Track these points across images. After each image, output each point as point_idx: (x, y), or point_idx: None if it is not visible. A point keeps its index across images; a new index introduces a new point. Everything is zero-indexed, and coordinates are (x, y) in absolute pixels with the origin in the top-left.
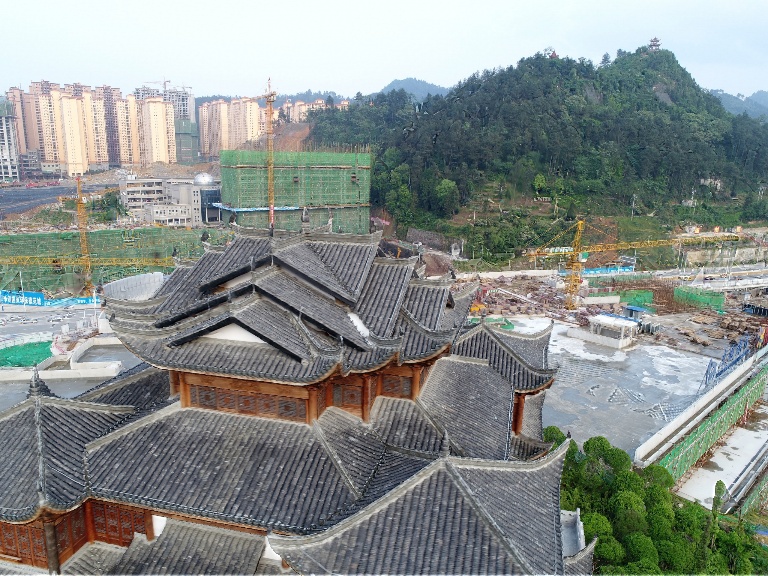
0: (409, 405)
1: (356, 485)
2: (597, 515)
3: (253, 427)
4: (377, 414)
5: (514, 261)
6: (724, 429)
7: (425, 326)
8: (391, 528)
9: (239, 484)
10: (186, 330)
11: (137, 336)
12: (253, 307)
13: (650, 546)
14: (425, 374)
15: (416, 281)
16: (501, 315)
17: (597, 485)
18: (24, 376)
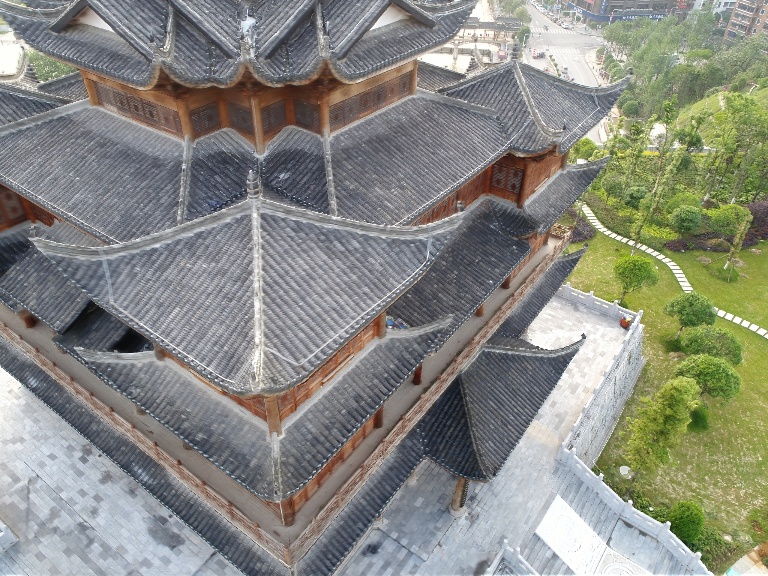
0: None
1: None
2: None
3: None
4: None
5: None
6: None
7: None
8: None
9: None
10: None
11: None
12: None
13: None
14: None
15: None
16: None
17: None
18: None
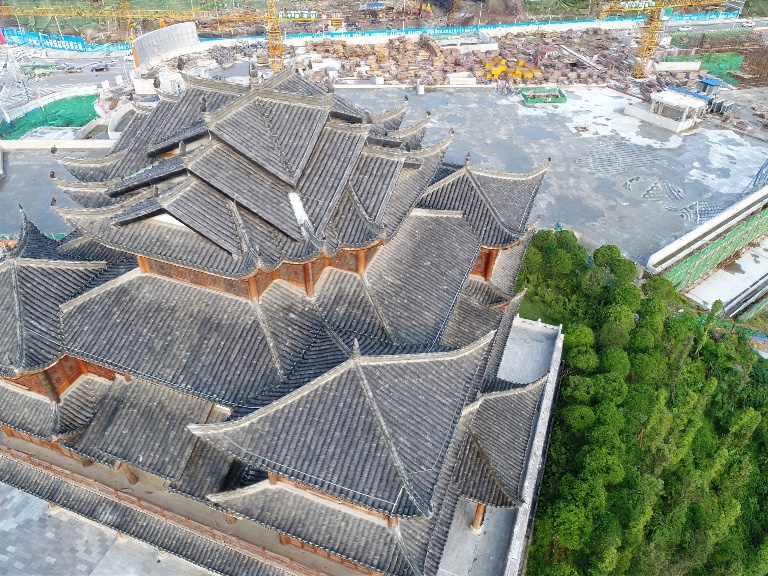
0: (354, 279)
1: (282, 369)
2: (582, 327)
3: (202, 299)
4: (323, 286)
5: (596, 2)
6: (761, 231)
7: (369, 208)
8: (300, 418)
9: (185, 356)
10: (130, 209)
11: (83, 216)
12: (188, 192)
13: (623, 361)
14: None
15: (370, 150)
16: (556, 84)
17: (595, 294)
18: (67, 144)
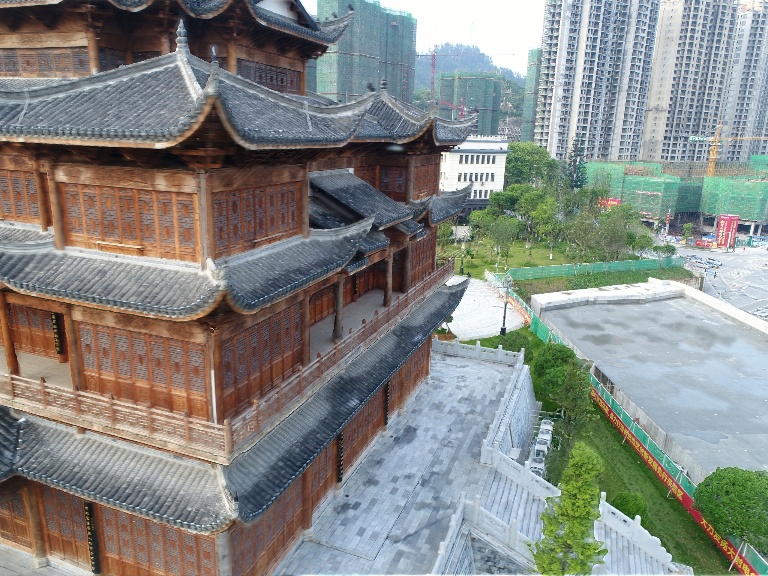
0: None
1: None
2: None
3: None
4: None
5: None
6: None
7: None
8: None
9: None
10: None
11: None
12: None
13: None
14: (28, 68)
15: None
16: None
17: None
18: (727, 309)
